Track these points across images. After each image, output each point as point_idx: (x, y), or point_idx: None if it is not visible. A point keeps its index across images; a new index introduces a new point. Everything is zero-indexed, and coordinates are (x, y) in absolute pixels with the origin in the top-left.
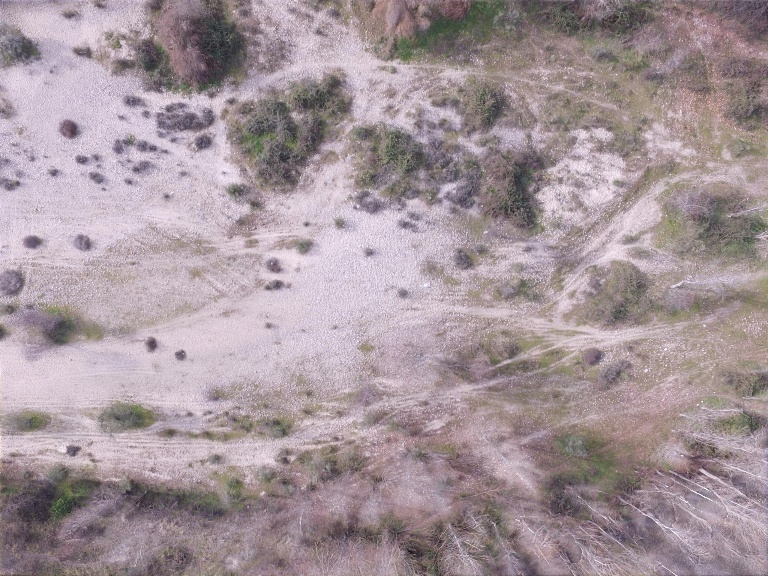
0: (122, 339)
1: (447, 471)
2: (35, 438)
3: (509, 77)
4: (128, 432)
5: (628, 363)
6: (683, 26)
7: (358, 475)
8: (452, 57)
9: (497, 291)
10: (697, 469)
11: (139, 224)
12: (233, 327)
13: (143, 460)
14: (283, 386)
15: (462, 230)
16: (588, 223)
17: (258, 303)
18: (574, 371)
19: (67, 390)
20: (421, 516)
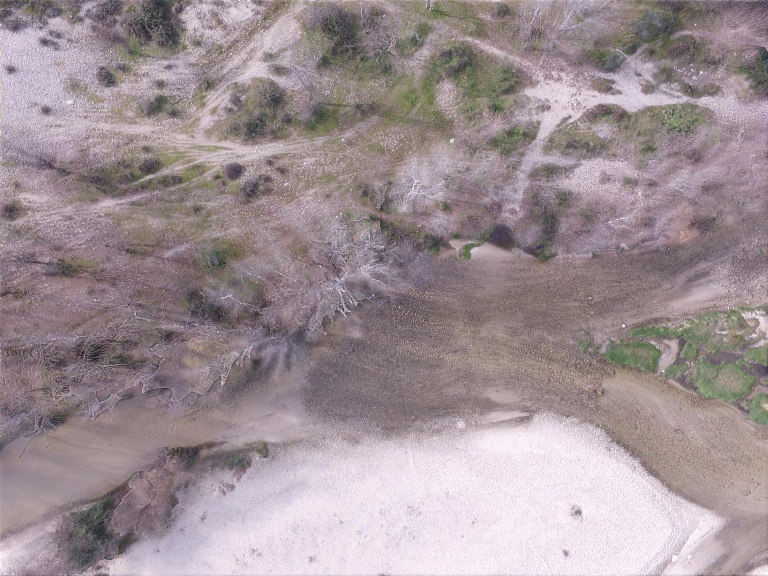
0: None
1: (92, 284)
2: None
3: None
4: None
5: (267, 176)
6: None
7: (4, 289)
8: None
9: (139, 107)
10: (332, 278)
11: None
12: None
13: None
14: None
15: (106, 49)
16: (228, 41)
17: None
18: (215, 185)
19: None
20: None
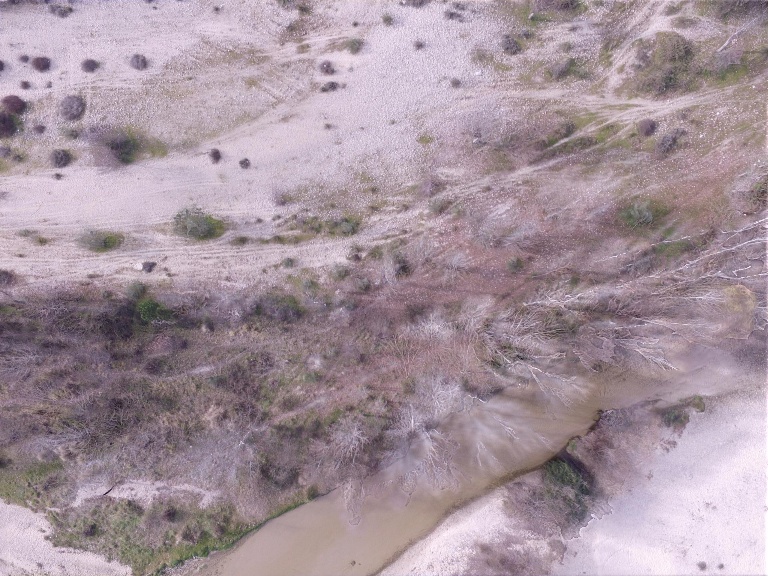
0: (186, 154)
1: (516, 253)
2: (110, 258)
3: None
4: (200, 244)
5: (683, 129)
6: None
7: (429, 265)
8: None
9: (548, 72)
10: None
11: (192, 39)
12: (293, 131)
13: (218, 270)
14: (347, 185)
15: (507, 17)
16: None
17: (315, 106)
18: (630, 143)
19: (137, 208)
20: (495, 299)
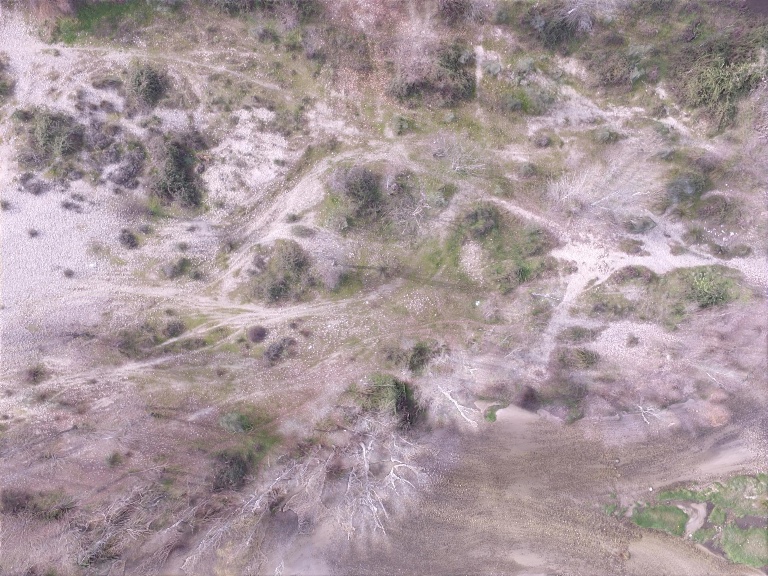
0: None
1: (116, 448)
2: None
3: (171, 58)
4: None
5: (291, 340)
6: (346, 6)
7: (29, 452)
8: (116, 39)
9: (162, 270)
10: (357, 443)
11: None
12: None
13: None
14: None
15: (128, 210)
16: (251, 202)
17: None
18: (239, 348)
19: None
20: (91, 492)
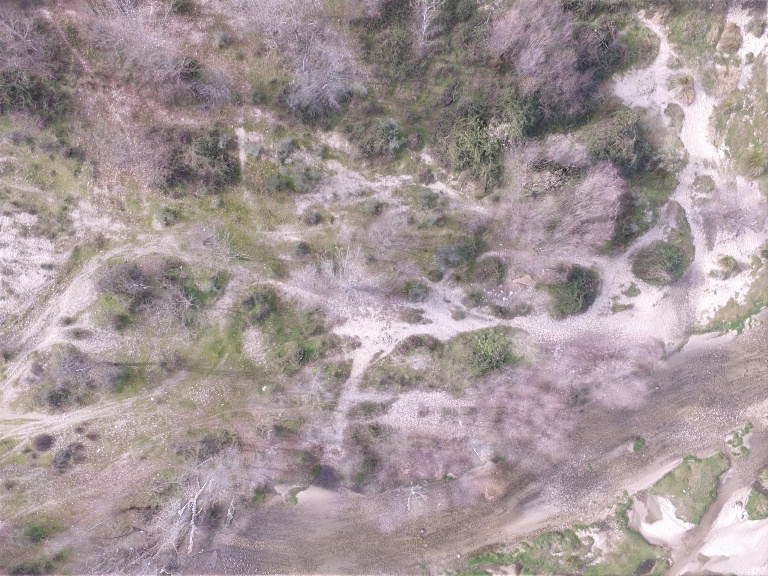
0: None
1: None
2: None
3: None
4: None
5: (77, 445)
6: (102, 100)
7: None
8: None
9: None
10: (154, 544)
11: None
12: None
13: None
14: None
15: None
16: (23, 309)
17: None
18: (26, 459)
19: None
20: None
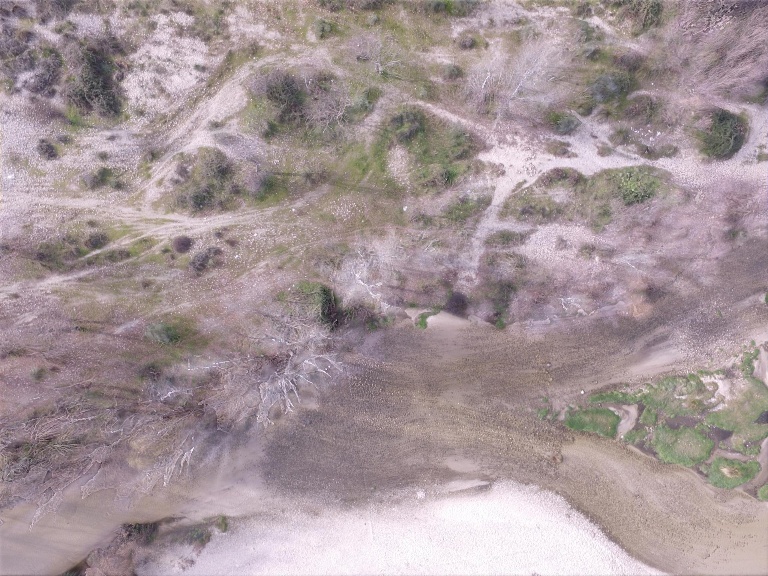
0: None
1: (41, 363)
2: None
3: None
4: None
5: (216, 249)
6: None
7: None
8: None
9: (82, 181)
10: (286, 352)
11: None
12: None
13: None
14: None
15: (46, 120)
16: (172, 109)
17: None
18: (164, 259)
19: None
20: (16, 409)
